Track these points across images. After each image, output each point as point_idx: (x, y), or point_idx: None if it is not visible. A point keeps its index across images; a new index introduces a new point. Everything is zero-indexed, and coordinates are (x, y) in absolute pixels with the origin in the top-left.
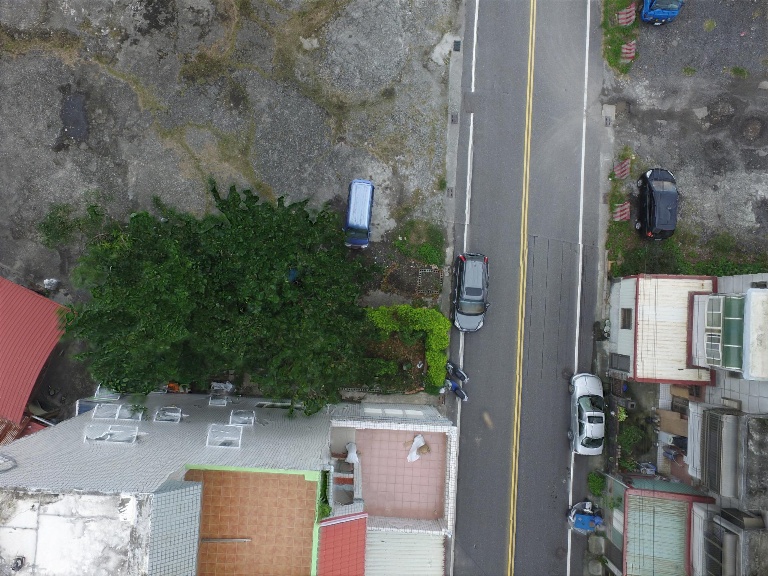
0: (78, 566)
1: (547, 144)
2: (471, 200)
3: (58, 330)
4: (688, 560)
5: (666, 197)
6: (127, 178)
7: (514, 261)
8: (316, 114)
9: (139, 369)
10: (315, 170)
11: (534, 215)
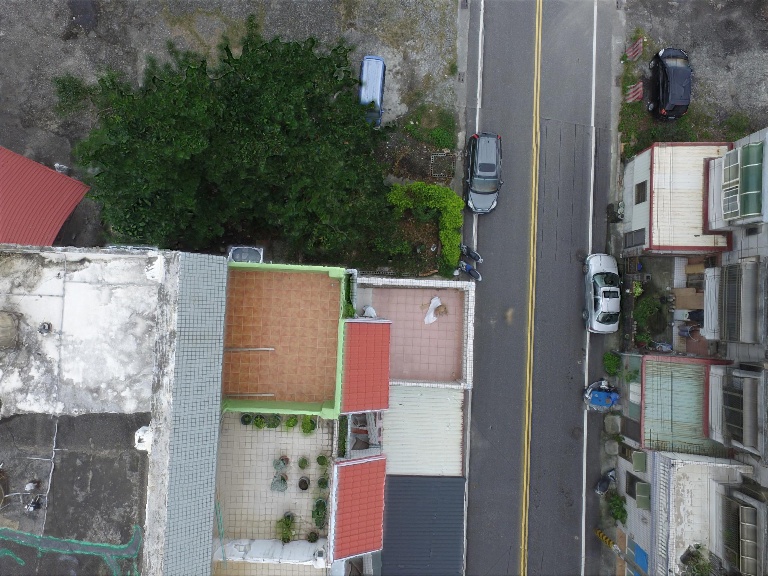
0: (105, 332)
1: (558, 27)
2: (483, 84)
3: (71, 202)
4: (707, 423)
5: (679, 75)
6: (136, 66)
7: (527, 144)
8: (325, 0)
9: (156, 208)
10: (325, 56)
11: (546, 98)
